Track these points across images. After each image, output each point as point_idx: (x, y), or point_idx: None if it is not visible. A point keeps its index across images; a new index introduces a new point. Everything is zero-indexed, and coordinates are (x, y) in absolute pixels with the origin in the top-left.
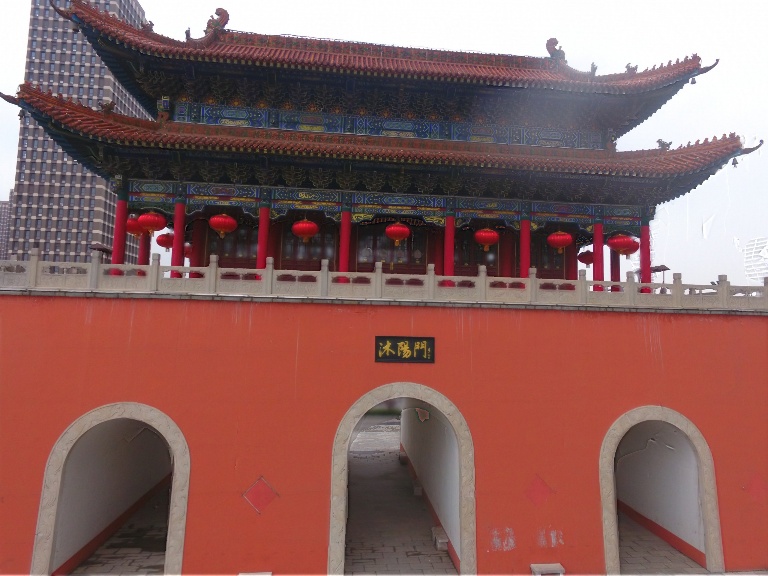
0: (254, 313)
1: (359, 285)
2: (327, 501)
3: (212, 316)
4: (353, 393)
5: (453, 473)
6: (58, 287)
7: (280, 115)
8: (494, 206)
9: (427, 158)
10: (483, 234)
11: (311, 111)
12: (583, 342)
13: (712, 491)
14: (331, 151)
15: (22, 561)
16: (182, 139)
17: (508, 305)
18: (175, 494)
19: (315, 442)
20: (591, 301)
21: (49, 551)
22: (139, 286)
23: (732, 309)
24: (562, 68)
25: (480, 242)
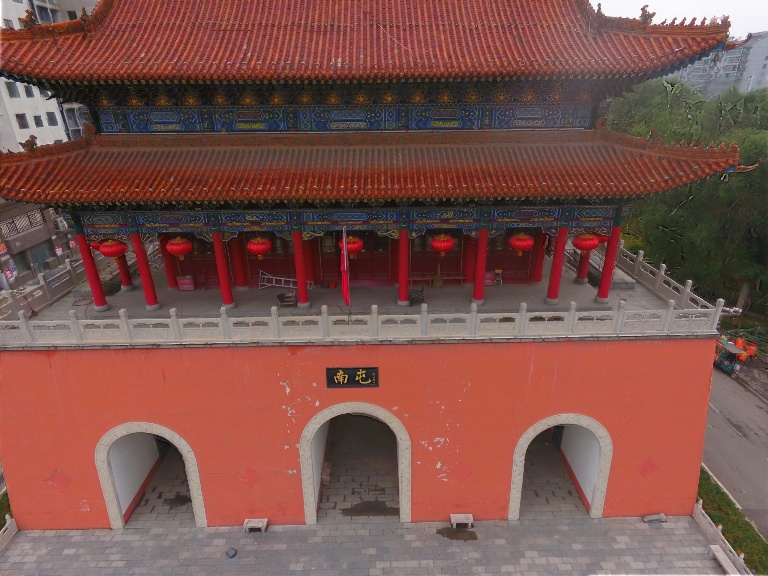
0: None
1: None
2: None
3: None
4: None
5: None
6: None
7: None
8: None
9: None
10: None
11: None
12: None
13: None
14: None
15: None
16: None
17: None
18: None
19: None
20: None
21: None
22: None
23: None
24: None
25: None
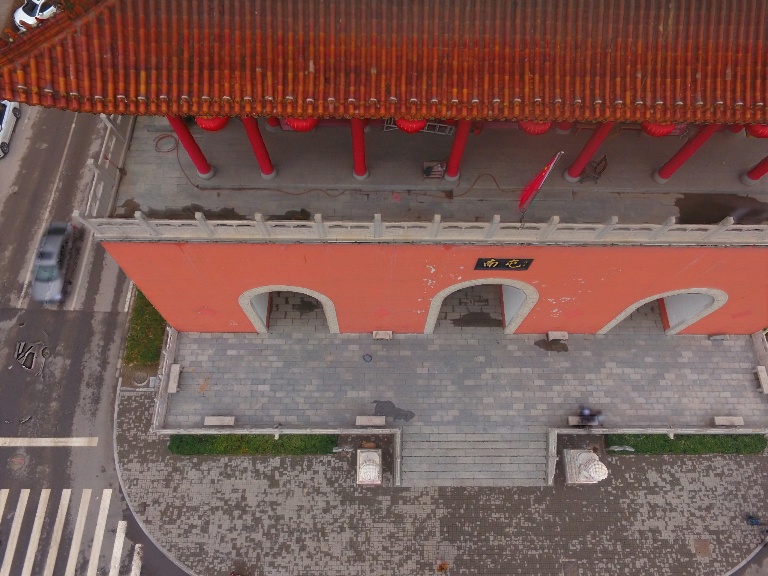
0: None
1: None
2: None
3: None
4: None
5: None
6: None
7: None
8: None
9: None
10: None
11: None
12: None
13: None
14: None
15: None
16: None
17: None
18: None
19: None
20: None
21: None
22: None
23: None
24: None
25: None
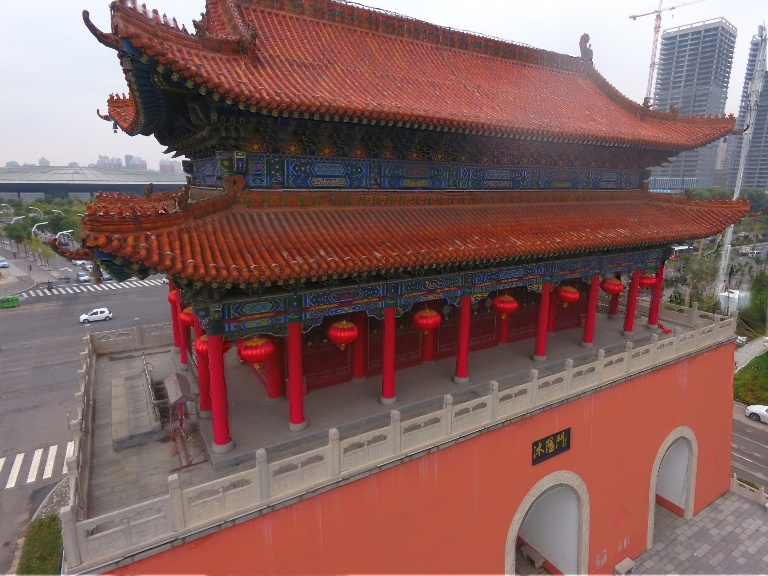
0: (439, 460)
1: (519, 398)
2: None
3: (401, 479)
4: (516, 499)
5: (561, 519)
6: (218, 516)
7: (383, 168)
8: (579, 266)
9: (570, 249)
10: (571, 296)
11: (414, 158)
12: (651, 395)
13: (694, 471)
14: (496, 256)
15: None
16: (344, 268)
17: (616, 382)
18: None
19: (492, 553)
20: (656, 359)
21: None
22: (318, 475)
23: (720, 342)
24: (595, 76)
25: (564, 301)
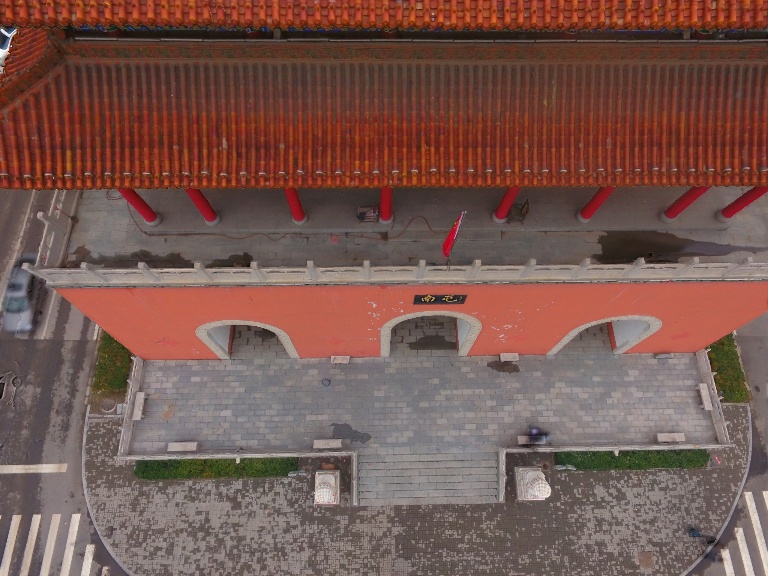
0: None
1: None
2: None
3: None
4: None
5: None
6: None
7: None
8: None
9: None
10: None
11: None
12: None
13: None
14: None
15: None
16: None
17: None
18: None
19: None
20: None
21: None
22: None
23: None
24: None
25: None
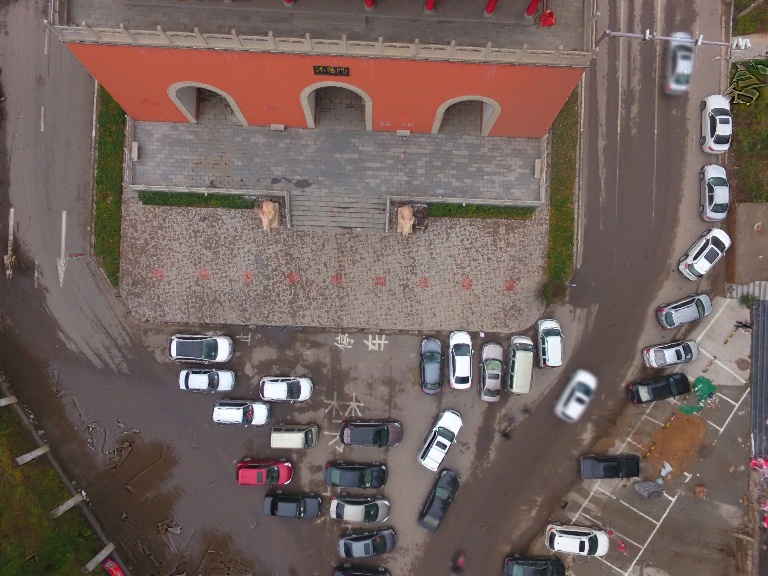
0: None
1: (297, 44)
2: (302, 111)
3: None
4: (305, 83)
5: None
6: (114, 40)
7: None
8: None
9: None
10: None
11: None
12: None
13: (494, 119)
14: None
15: (182, 116)
16: None
17: (396, 58)
18: (232, 106)
19: (290, 96)
20: (455, 55)
21: (190, 115)
22: (160, 40)
23: (554, 65)
24: None
25: None
